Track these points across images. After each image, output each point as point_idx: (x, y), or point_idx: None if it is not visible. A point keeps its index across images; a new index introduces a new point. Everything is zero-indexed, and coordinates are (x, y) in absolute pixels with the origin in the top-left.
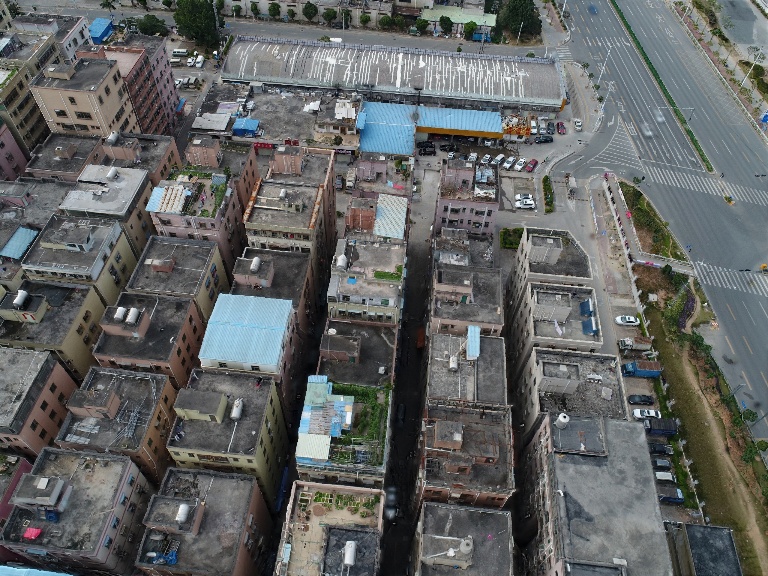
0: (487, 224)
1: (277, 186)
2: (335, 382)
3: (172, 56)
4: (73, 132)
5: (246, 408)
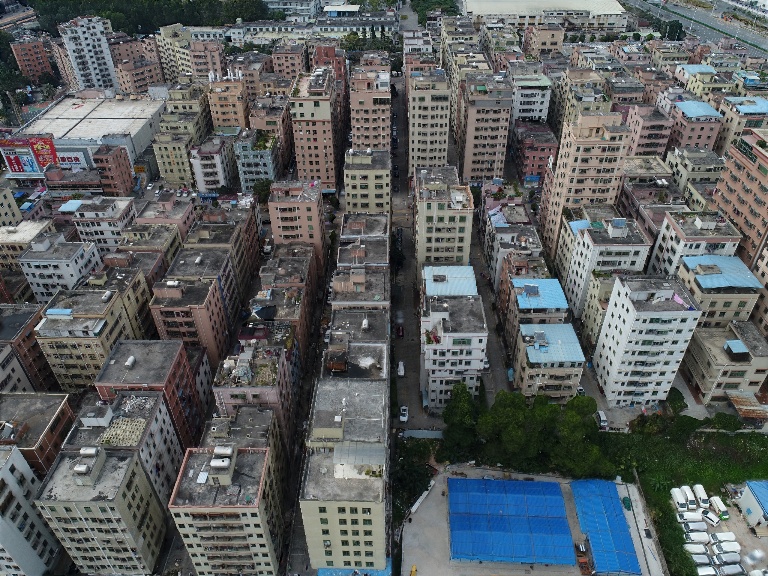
0: None
1: None
2: None
3: None
4: None
5: None
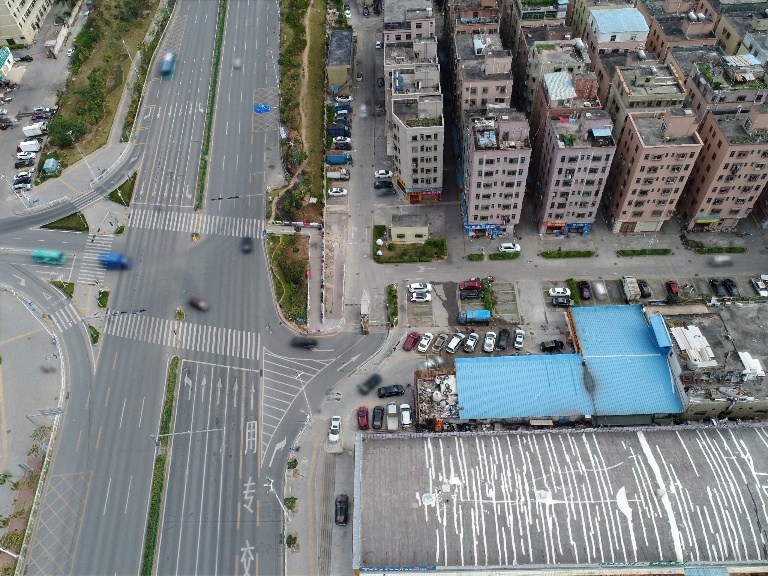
0: None
1: None
2: (554, 5)
3: None
4: None
5: (595, 0)
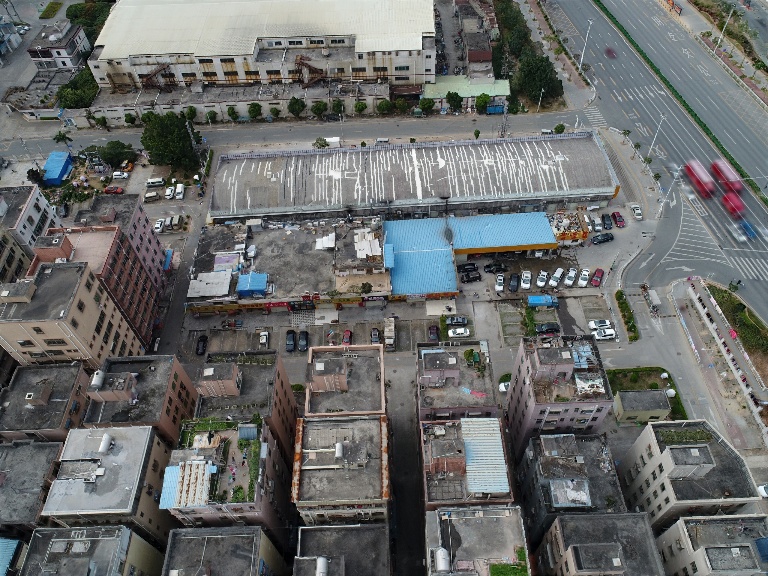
0: (595, 418)
1: (324, 425)
2: None
3: (146, 187)
4: (45, 358)
5: None
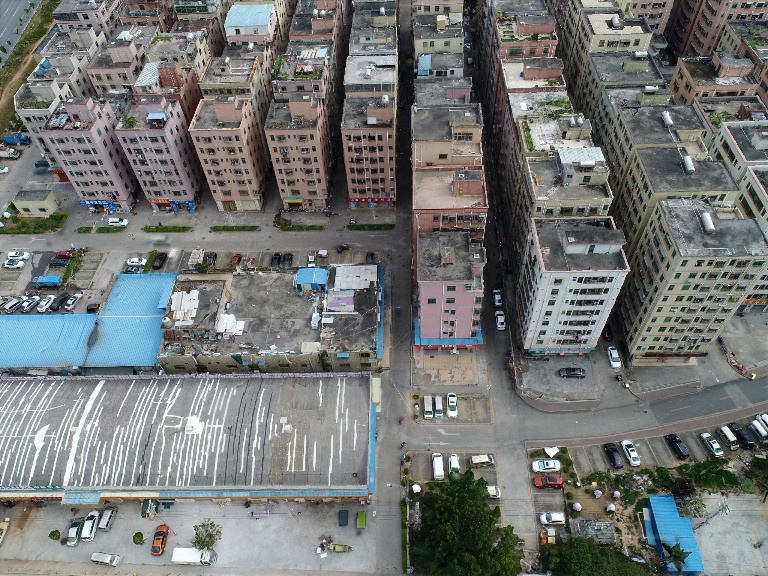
0: None
1: None
2: (201, 0)
3: None
4: None
5: None
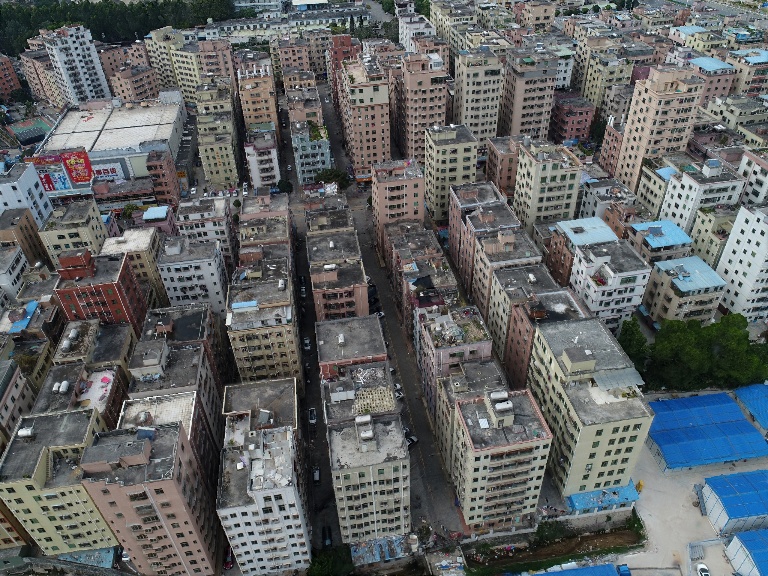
0: None
1: None
2: None
3: None
4: None
5: None
